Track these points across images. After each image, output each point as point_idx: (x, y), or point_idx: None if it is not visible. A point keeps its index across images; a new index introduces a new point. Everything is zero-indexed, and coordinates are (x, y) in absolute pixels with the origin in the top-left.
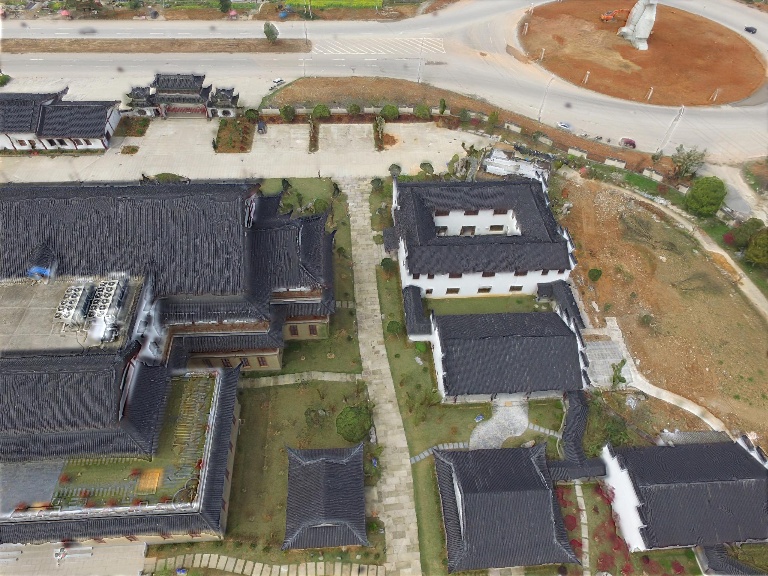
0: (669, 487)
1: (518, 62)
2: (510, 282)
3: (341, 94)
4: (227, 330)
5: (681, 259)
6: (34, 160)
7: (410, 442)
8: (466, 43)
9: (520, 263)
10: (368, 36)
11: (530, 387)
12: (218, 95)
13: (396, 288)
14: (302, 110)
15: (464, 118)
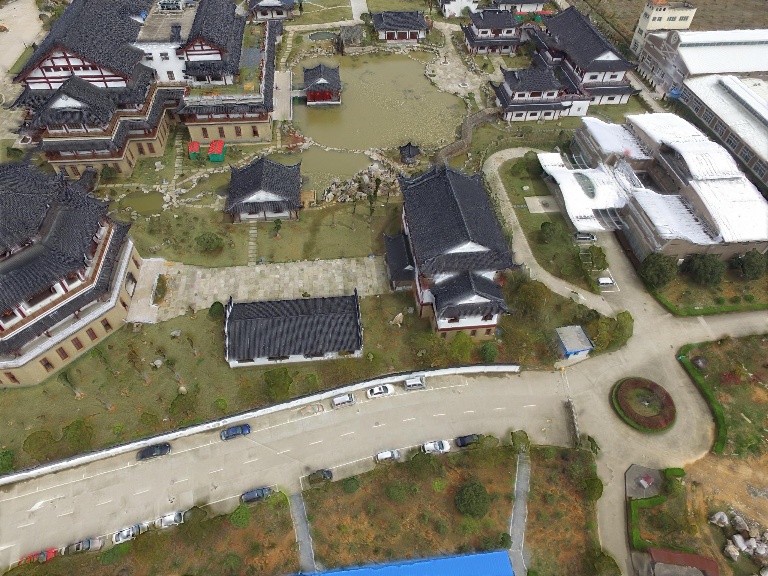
0: None
1: None
2: None
3: None
4: None
5: None
6: None
7: None
8: None
9: None
10: None
11: None
12: None
13: None
14: None
15: None
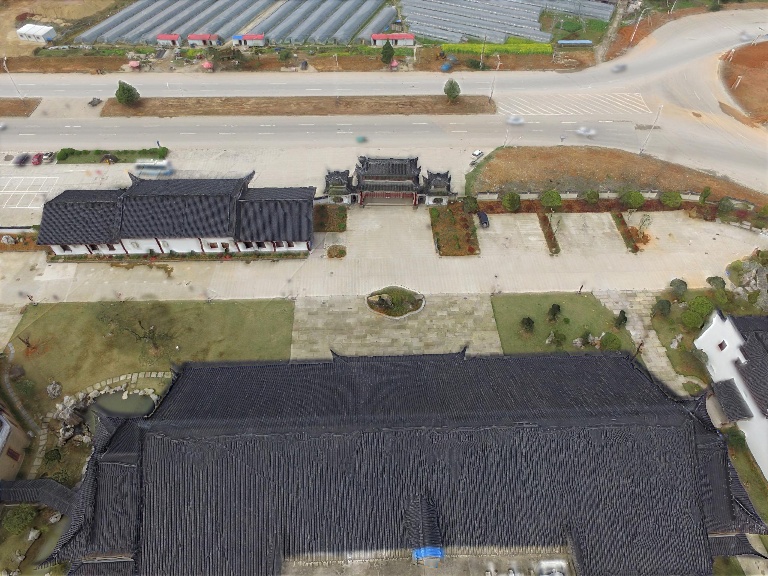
0: None
1: (742, 125)
2: None
3: (555, 170)
4: None
5: None
6: (227, 266)
7: None
8: (670, 100)
9: None
10: (554, 91)
11: None
12: (433, 181)
13: (751, 470)
14: (524, 195)
15: (727, 208)
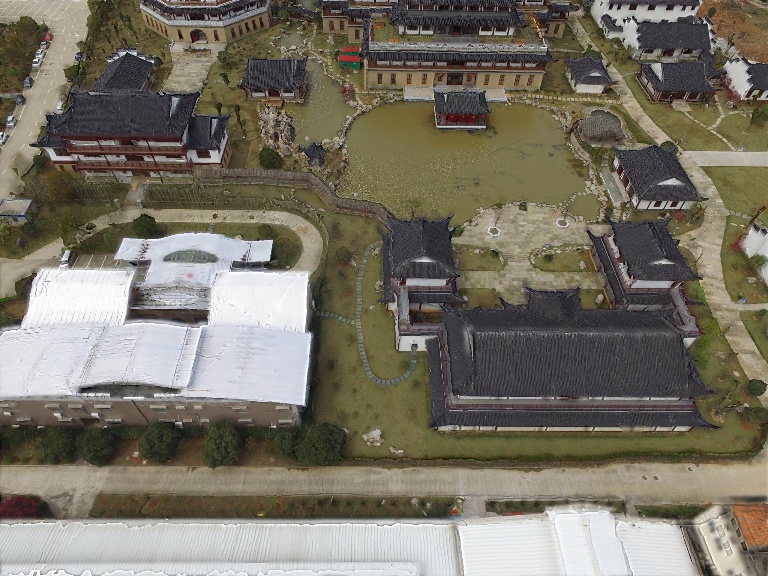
0: (762, 65)
1: None
2: (662, 16)
3: None
4: (528, 8)
5: (761, 17)
6: None
7: (619, 71)
8: None
9: (670, 1)
10: None
11: (683, 47)
12: None
13: (592, 24)
14: None
15: None
